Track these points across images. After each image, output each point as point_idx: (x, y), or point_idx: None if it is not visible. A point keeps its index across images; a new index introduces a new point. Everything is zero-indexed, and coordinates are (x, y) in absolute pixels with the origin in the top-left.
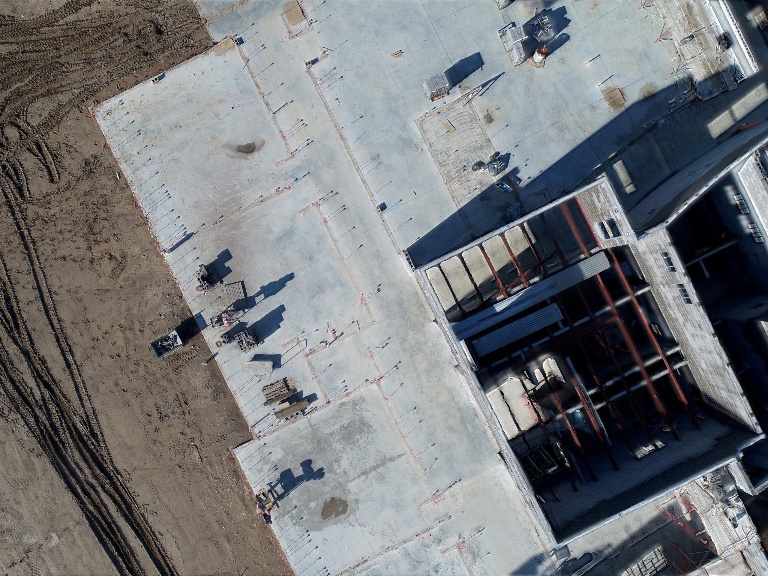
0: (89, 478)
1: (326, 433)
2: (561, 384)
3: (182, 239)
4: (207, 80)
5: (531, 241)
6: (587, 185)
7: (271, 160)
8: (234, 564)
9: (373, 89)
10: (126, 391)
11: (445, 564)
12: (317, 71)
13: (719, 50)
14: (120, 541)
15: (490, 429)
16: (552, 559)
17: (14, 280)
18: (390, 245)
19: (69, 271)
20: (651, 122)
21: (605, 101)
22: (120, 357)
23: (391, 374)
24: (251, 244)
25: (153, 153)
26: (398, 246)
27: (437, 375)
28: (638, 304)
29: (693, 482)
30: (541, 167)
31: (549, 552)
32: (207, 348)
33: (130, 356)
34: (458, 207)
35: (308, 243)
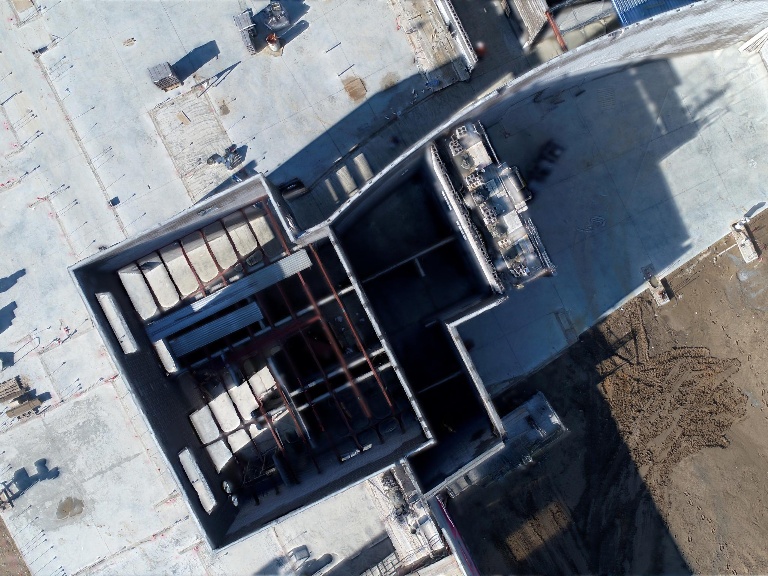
0: None
1: (60, 432)
2: None
3: None
4: None
5: (230, 238)
6: (242, 182)
7: (0, 153)
8: None
9: (105, 79)
10: None
11: (182, 564)
12: (46, 60)
13: (435, 39)
14: None
15: None
16: (291, 560)
17: None
18: None
19: None
20: (393, 113)
21: (346, 91)
22: None
23: None
24: None
25: None
26: None
27: None
28: (341, 304)
29: (374, 487)
30: (279, 160)
31: (288, 553)
32: None
33: None
34: (193, 202)
35: (39, 238)
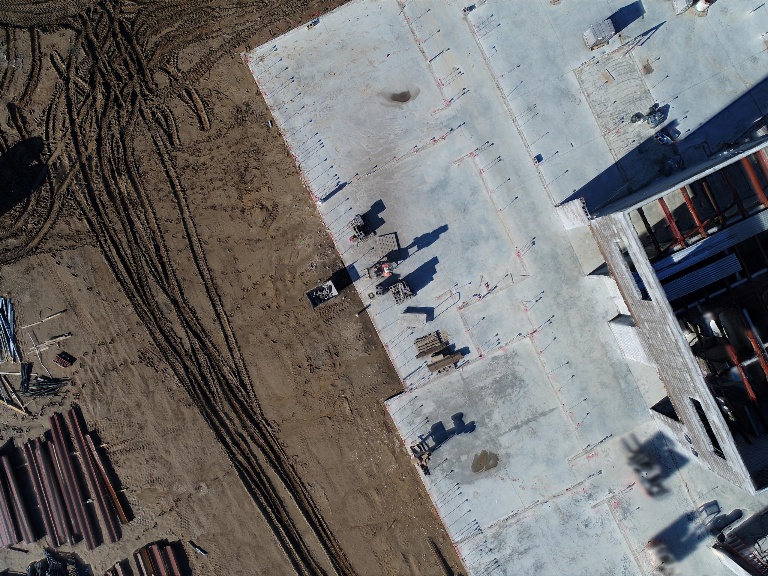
0: (238, 428)
1: (478, 386)
2: (717, 340)
3: (335, 189)
4: (362, 26)
5: None
6: None
7: (426, 109)
8: (383, 515)
9: (531, 37)
10: (276, 342)
11: (594, 518)
12: (474, 18)
13: None
14: (269, 491)
15: (662, 381)
16: (702, 515)
17: (163, 229)
18: (546, 197)
19: (219, 221)
20: None
21: None
22: (270, 308)
23: (544, 328)
24: (405, 195)
25: (306, 101)
26: (554, 199)
27: (590, 330)
28: None
29: None
30: (701, 119)
31: (699, 508)
32: (359, 300)
33: (280, 307)
34: (615, 159)
35: (463, 195)
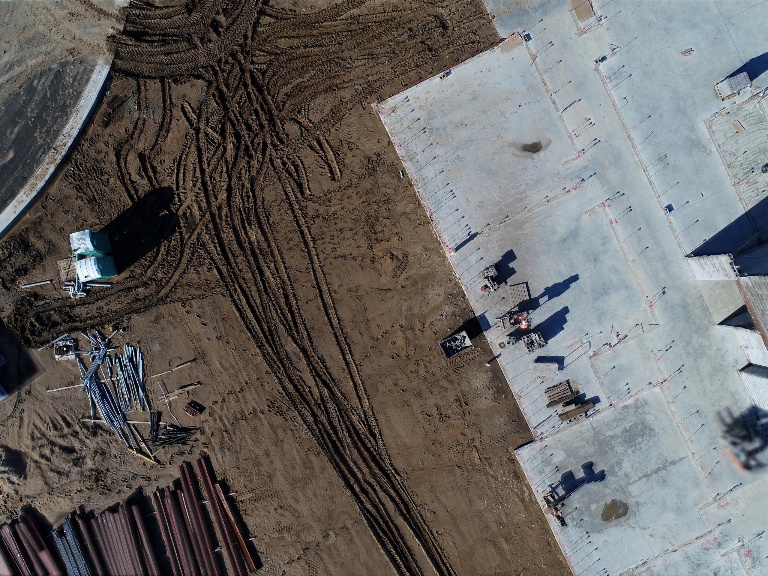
0: (367, 477)
1: (608, 435)
2: None
3: (466, 239)
4: (494, 77)
5: None
6: None
7: (557, 160)
8: (511, 564)
9: (662, 88)
10: (405, 391)
11: (724, 567)
12: (606, 69)
13: None
14: (397, 540)
15: None
16: None
17: (293, 278)
18: (676, 247)
19: (349, 270)
20: None
21: None
22: (400, 357)
23: (674, 377)
24: (536, 245)
25: (438, 151)
26: (684, 248)
27: (720, 379)
28: None
29: None
30: None
31: None
32: (489, 349)
33: (410, 356)
34: (746, 209)
35: (593, 244)
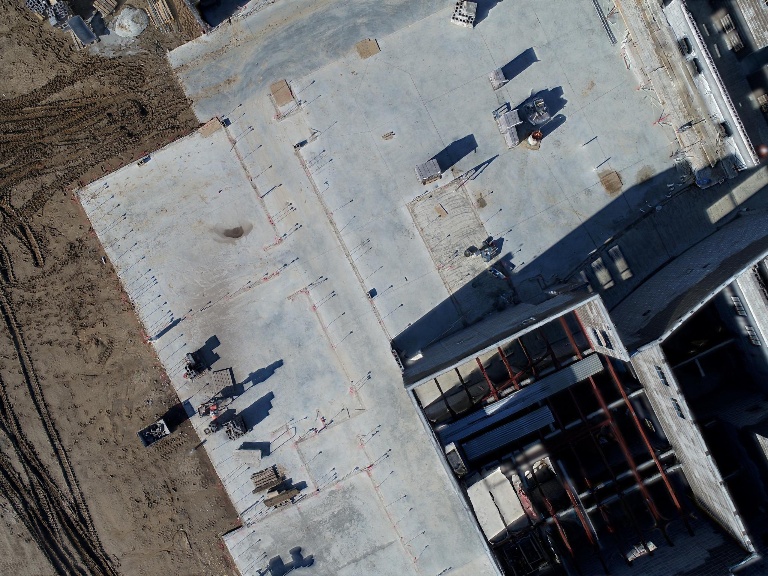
0: (78, 563)
1: (315, 520)
2: (553, 473)
3: (169, 325)
4: (193, 163)
5: None
6: (579, 303)
7: (259, 245)
8: None
9: (363, 172)
10: (114, 477)
11: None
12: (306, 153)
13: (719, 143)
14: None
15: None
16: None
17: (0, 365)
18: (380, 332)
19: (55, 356)
20: (649, 206)
21: (602, 185)
22: (108, 443)
23: (381, 462)
24: (239, 330)
25: (139, 238)
26: (389, 333)
27: (428, 463)
28: (631, 407)
29: None
30: (535, 252)
31: None
32: (195, 435)
33: (118, 442)
34: (450, 293)
35: (297, 329)
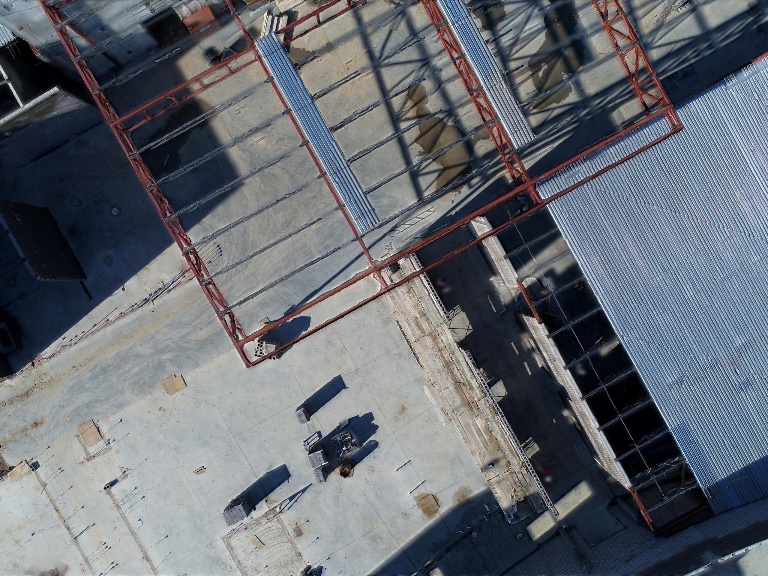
0: None
1: None
2: None
3: None
4: (5, 507)
5: None
6: None
7: None
8: None
9: (177, 507)
10: None
11: None
12: (118, 492)
13: (514, 498)
14: None
15: None
16: None
17: None
18: None
19: None
20: (467, 527)
21: (418, 508)
22: None
23: None
24: None
25: None
26: None
27: None
28: None
29: None
30: None
31: None
32: None
33: None
34: None
35: None
